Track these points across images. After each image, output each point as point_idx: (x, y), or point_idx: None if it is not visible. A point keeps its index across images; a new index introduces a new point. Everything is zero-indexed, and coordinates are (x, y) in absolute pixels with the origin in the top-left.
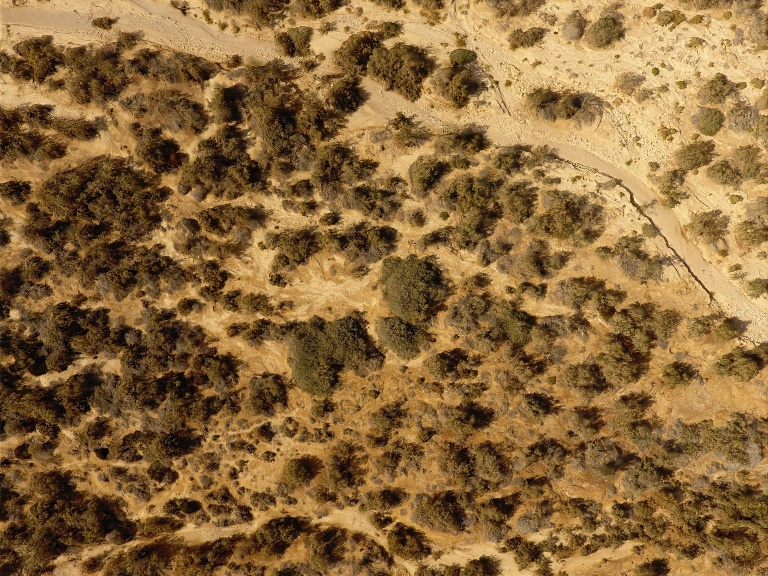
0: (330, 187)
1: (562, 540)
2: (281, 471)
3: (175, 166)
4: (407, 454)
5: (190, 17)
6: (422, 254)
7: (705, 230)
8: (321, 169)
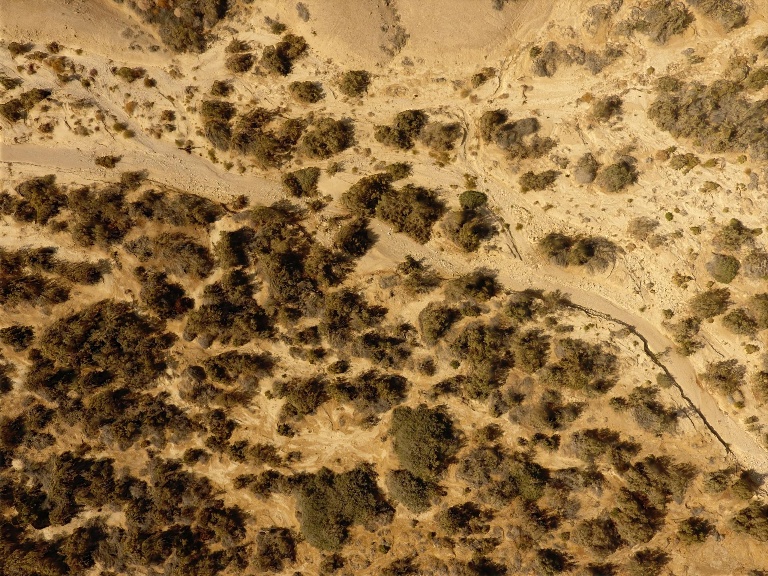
0: (338, 336)
1: None
2: None
3: (180, 312)
4: None
5: (195, 155)
6: (432, 404)
7: (721, 382)
8: (329, 318)
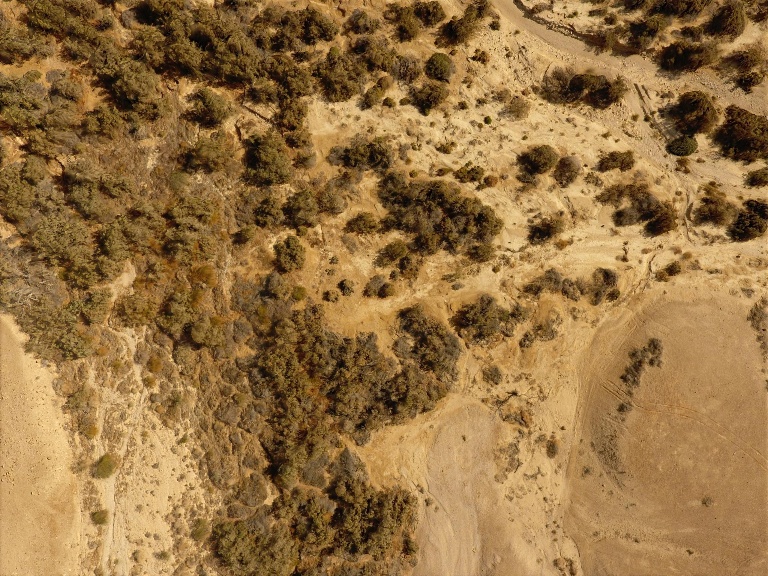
0: None
1: None
2: None
3: None
4: None
5: None
6: None
7: None
8: None
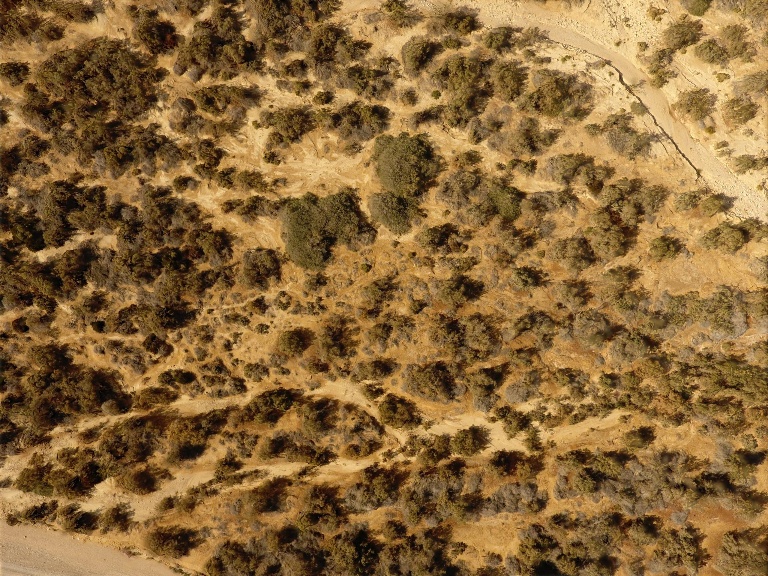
0: (324, 66)
1: (550, 410)
2: (274, 343)
3: (171, 47)
4: (398, 325)
5: None
6: (414, 132)
7: (692, 107)
8: (315, 47)
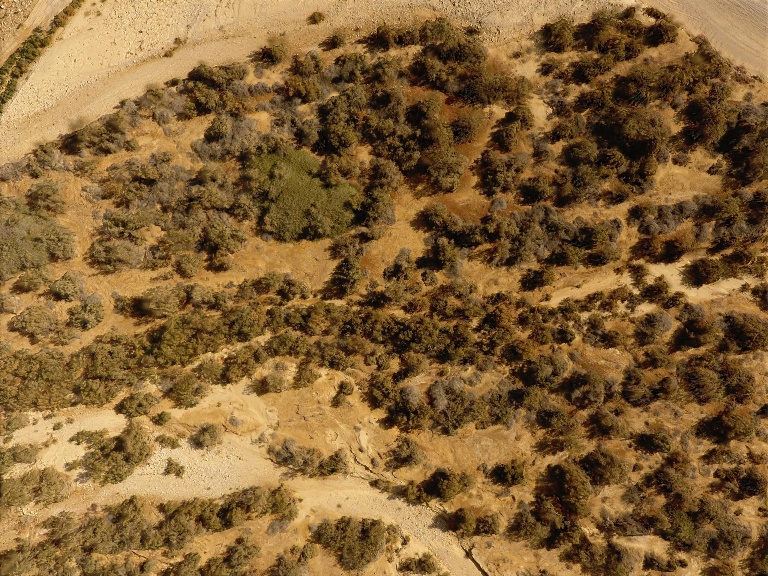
0: None
1: (622, 306)
2: None
3: None
4: None
5: None
6: None
7: None
8: None
